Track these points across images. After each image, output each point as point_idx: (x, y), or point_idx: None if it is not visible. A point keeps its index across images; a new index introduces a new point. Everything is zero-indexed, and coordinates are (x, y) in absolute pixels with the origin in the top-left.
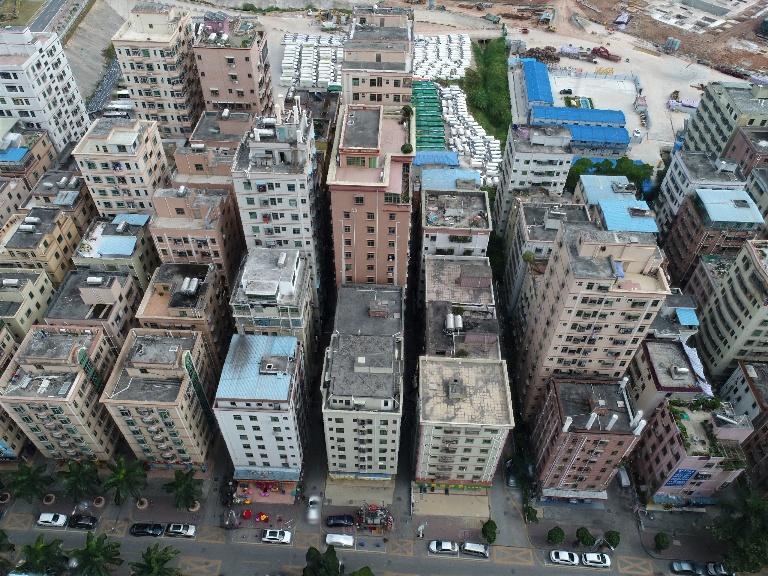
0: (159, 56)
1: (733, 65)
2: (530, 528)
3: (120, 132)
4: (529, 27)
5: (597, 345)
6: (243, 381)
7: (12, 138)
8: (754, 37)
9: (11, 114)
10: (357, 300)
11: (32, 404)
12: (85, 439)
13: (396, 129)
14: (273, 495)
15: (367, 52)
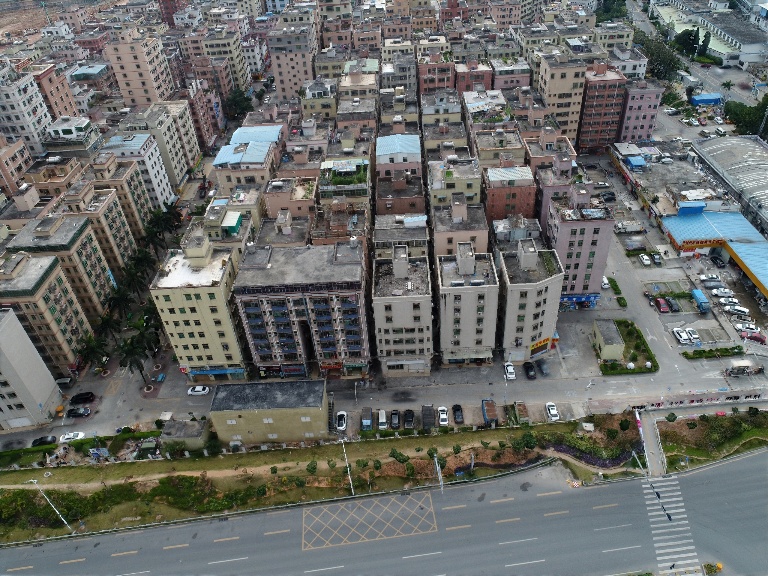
0: None
1: None
2: None
3: None
4: None
5: None
6: None
7: None
8: None
9: None
10: None
11: None
12: None
13: None
14: None
15: None
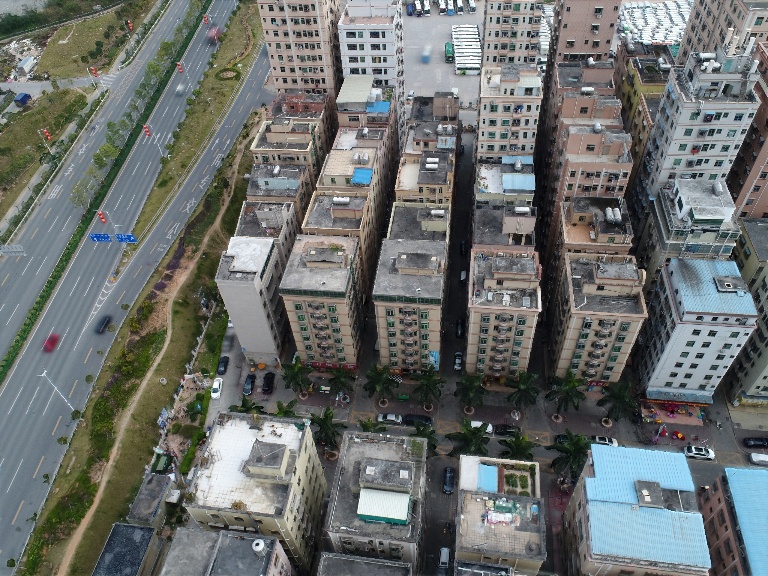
0: (528, 9)
1: None
2: None
3: (523, 76)
4: None
5: None
6: (705, 298)
7: (376, 92)
8: None
9: (365, 72)
10: (763, 233)
11: (505, 314)
12: (521, 353)
13: None
14: (680, 417)
15: None
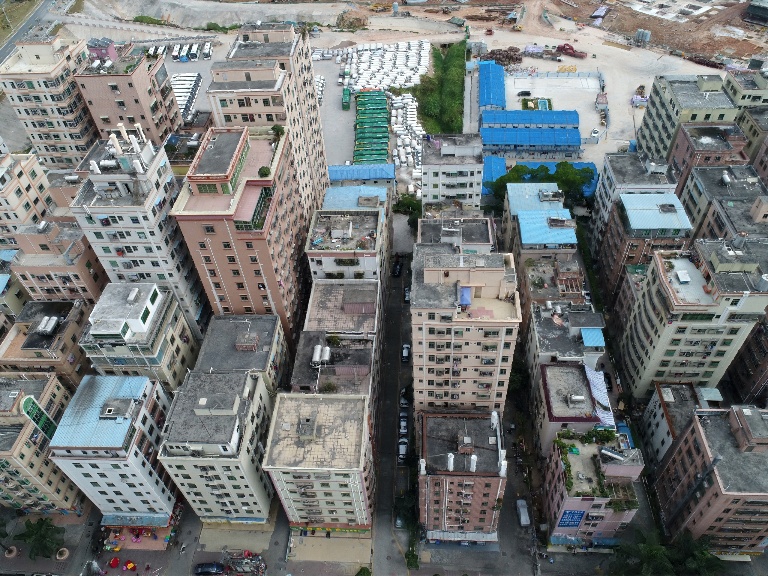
0: (44, 87)
1: (715, 54)
2: (413, 574)
3: None
4: (495, 28)
5: (464, 377)
6: (81, 427)
7: None
8: (740, 22)
9: None
10: (229, 332)
11: None
12: None
13: (265, 150)
14: (145, 541)
15: (235, 71)
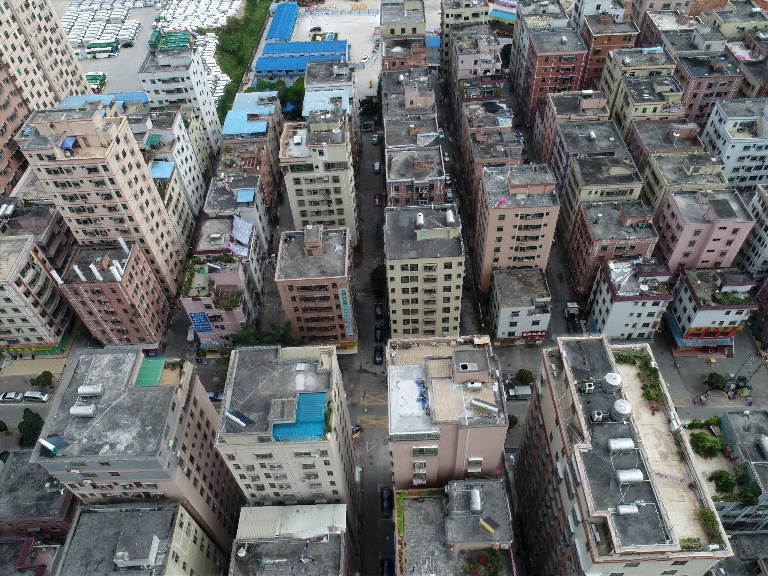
0: None
1: None
2: None
3: None
4: None
5: (100, 214)
6: None
7: None
8: None
9: None
10: None
11: None
12: None
13: None
14: None
15: None
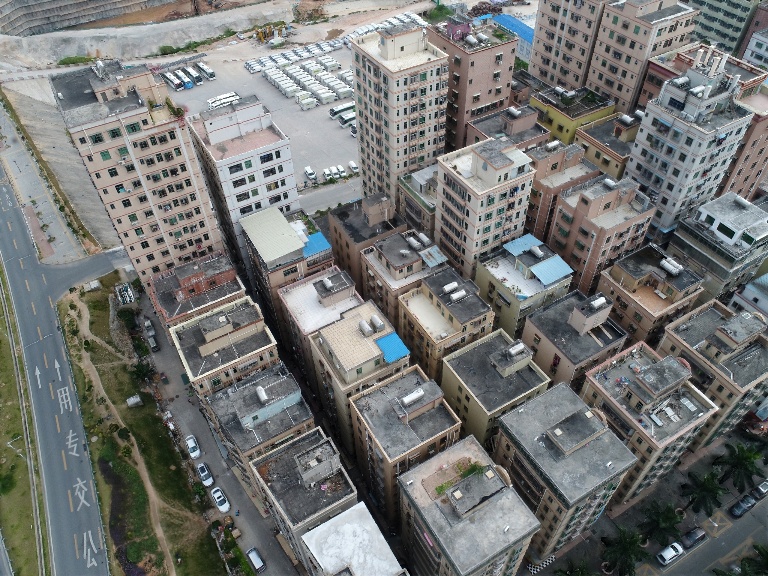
0: (434, 76)
1: None
2: None
3: None
4: None
5: None
6: None
7: (299, 227)
8: None
9: (260, 206)
10: None
11: (689, 433)
12: None
13: None
14: None
15: (655, 3)
